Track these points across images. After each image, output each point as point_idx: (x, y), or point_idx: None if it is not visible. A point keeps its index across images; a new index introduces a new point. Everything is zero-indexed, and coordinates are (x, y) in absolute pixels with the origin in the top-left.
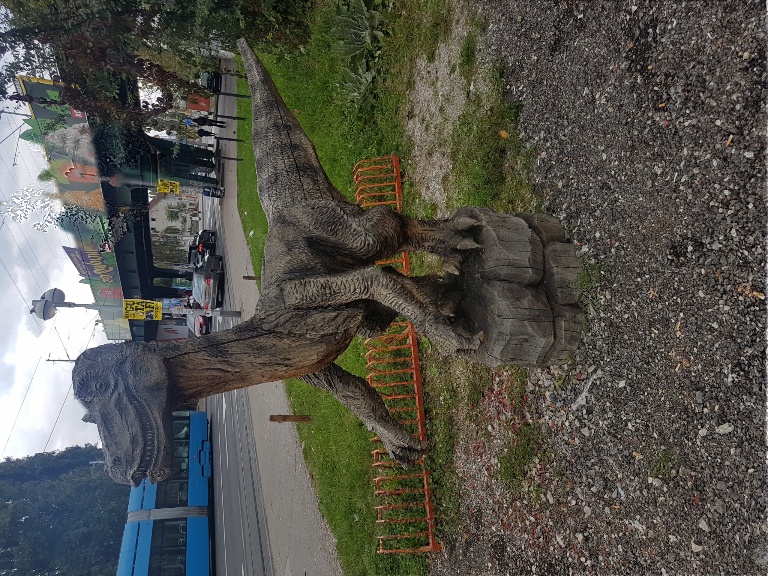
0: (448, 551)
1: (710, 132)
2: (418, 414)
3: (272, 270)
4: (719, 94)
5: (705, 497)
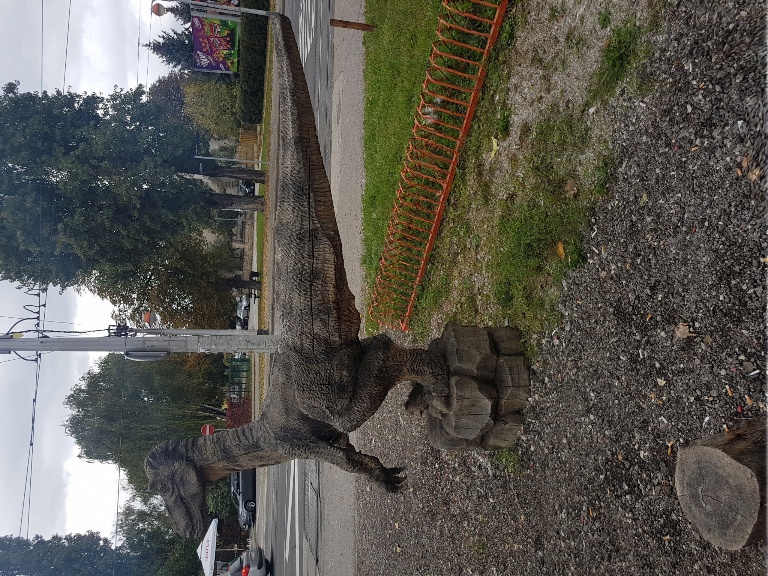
0: (412, 338)
1: (580, 570)
2: (425, 255)
3: (274, 418)
4: (598, 575)
5: (483, 572)
